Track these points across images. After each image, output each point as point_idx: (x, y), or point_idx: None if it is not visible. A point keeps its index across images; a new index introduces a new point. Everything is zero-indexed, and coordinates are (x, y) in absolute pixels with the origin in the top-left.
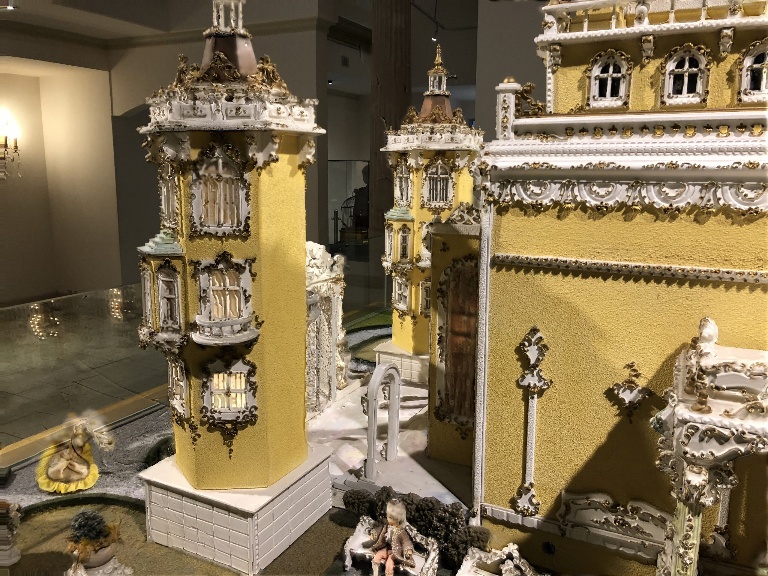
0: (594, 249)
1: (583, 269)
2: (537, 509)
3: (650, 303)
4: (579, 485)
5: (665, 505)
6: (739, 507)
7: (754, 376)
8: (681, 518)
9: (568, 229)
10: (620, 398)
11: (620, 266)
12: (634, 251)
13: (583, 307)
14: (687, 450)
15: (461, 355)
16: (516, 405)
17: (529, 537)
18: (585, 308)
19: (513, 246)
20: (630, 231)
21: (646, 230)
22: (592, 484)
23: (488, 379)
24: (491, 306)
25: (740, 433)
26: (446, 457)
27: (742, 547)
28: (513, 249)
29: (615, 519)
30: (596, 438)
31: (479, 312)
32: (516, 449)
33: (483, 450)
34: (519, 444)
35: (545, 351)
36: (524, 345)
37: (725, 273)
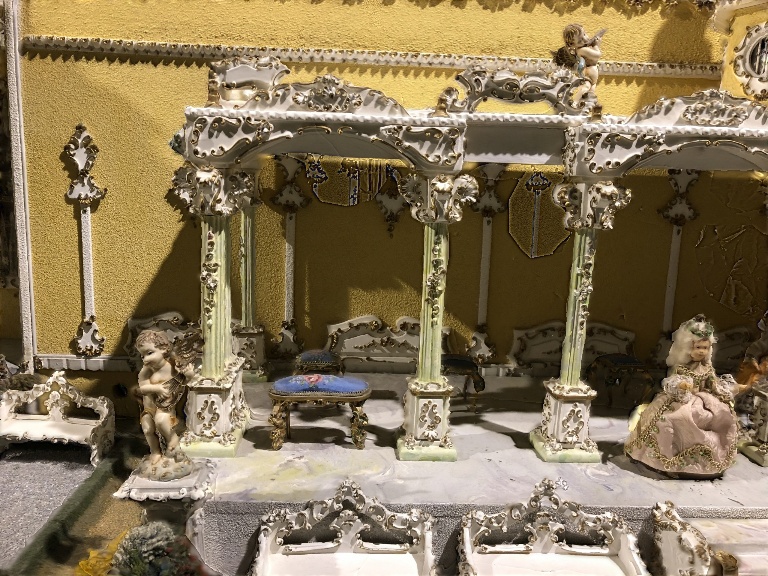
0: (140, 29)
1: (130, 52)
2: (101, 346)
3: (204, 90)
4: (147, 309)
5: (236, 312)
6: (303, 299)
7: (261, 67)
8: (203, 240)
9: (110, 5)
10: (181, 199)
11: (169, 46)
12: (183, 31)
13: (134, 98)
14: (197, 149)
15: (13, 199)
16: (67, 225)
17: (96, 384)
18: (136, 99)
19: (47, 26)
20: (177, 8)
21: (193, 7)
22: (161, 305)
23: (29, 197)
24: (25, 103)
25: (246, 119)
26: (5, 333)
27: (308, 340)
28: (47, 30)
29: (185, 336)
30: (161, 251)
31: (10, 111)
32: (72, 280)
33: (30, 287)
34: (75, 273)
35: (95, 153)
36: (69, 148)
37: (271, 50)
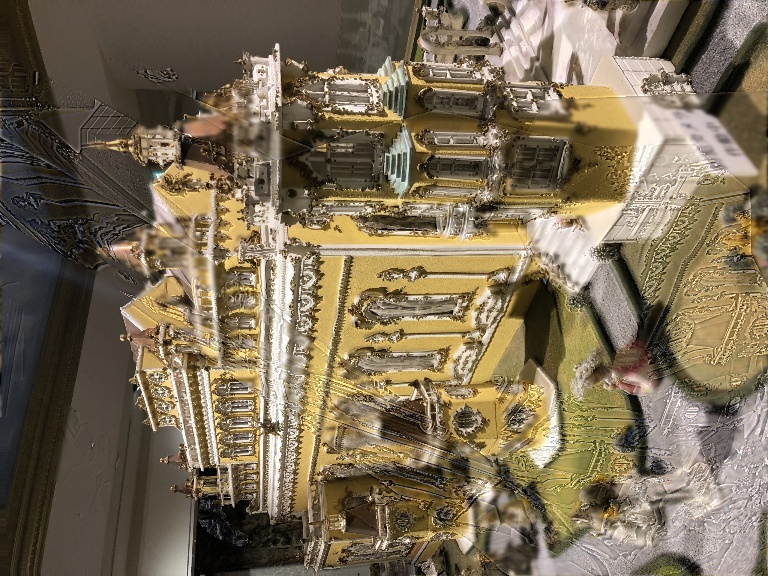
0: None
1: None
2: None
3: None
4: None
5: None
6: None
7: None
8: None
9: None
10: None
11: None
12: None
13: None
14: None
15: None
16: None
17: None
18: None
19: None
20: None
21: None
22: None
23: None
24: None
25: None
26: None
27: None
28: None
29: None
30: None
31: None
32: None
33: None
34: None
35: None
36: None
37: None
